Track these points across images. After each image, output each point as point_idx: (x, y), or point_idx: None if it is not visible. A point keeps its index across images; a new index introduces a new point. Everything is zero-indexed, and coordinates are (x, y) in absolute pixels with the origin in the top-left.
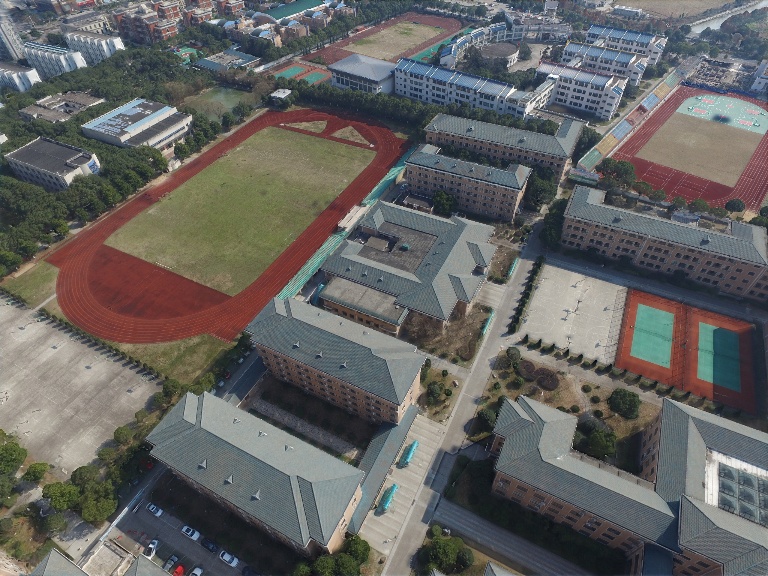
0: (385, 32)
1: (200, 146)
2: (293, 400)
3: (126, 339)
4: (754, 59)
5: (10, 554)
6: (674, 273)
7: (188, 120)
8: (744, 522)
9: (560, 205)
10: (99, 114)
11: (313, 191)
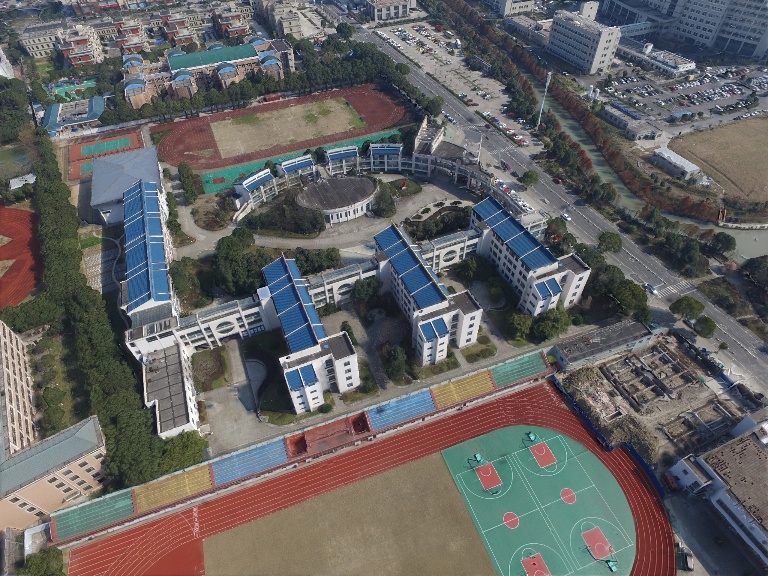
0: (293, 110)
1: None
2: None
3: None
4: None
5: None
6: None
7: None
8: None
9: None
10: None
11: None
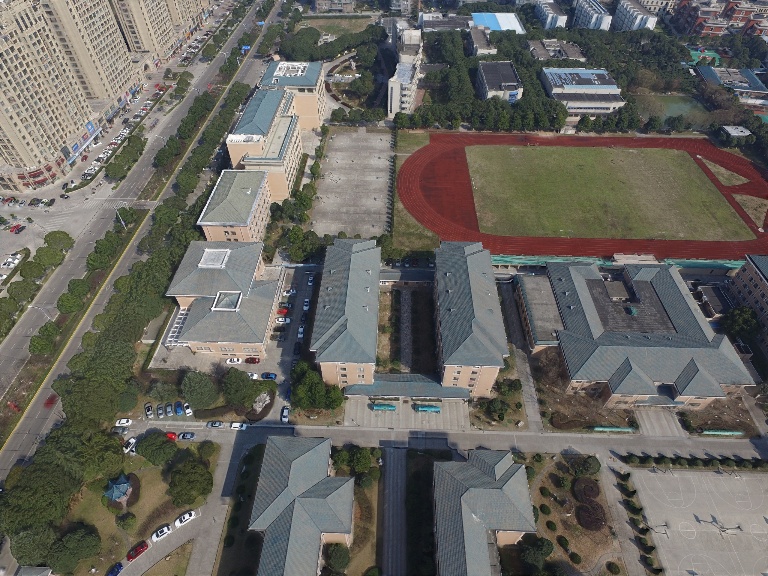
0: None
1: (605, 130)
2: (422, 311)
3: (405, 202)
4: None
5: (264, 238)
6: None
7: (619, 105)
8: None
9: None
10: (566, 67)
11: (639, 220)
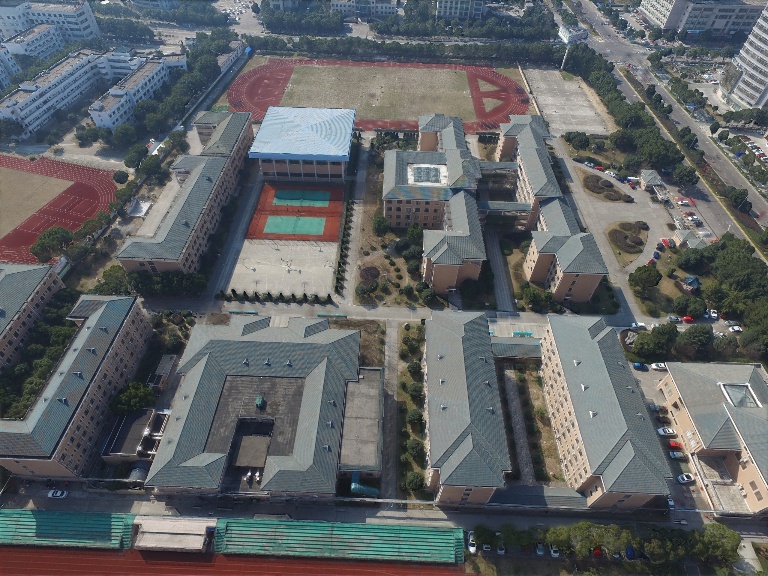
0: None
1: None
2: None
3: None
4: None
5: None
6: (223, 213)
7: None
8: (450, 170)
9: (142, 276)
10: None
11: None
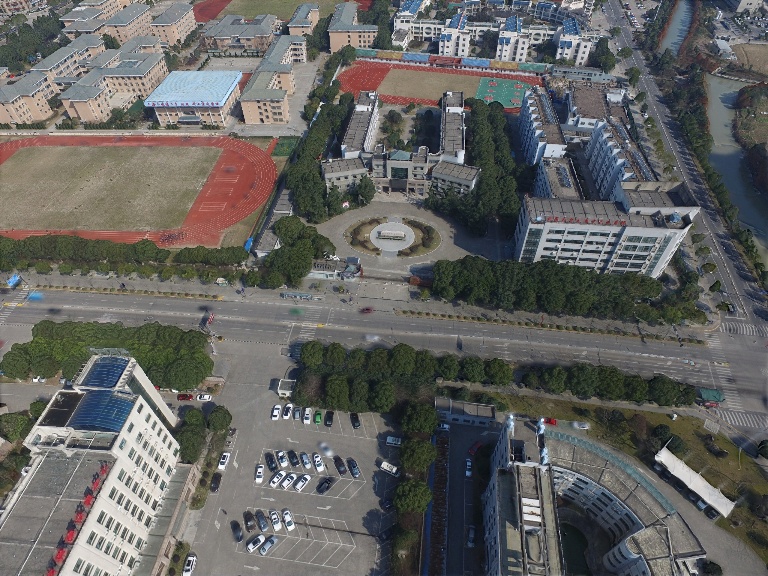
0: None
1: None
2: None
3: None
4: (667, 104)
5: None
6: None
7: None
8: None
9: None
10: None
11: None
